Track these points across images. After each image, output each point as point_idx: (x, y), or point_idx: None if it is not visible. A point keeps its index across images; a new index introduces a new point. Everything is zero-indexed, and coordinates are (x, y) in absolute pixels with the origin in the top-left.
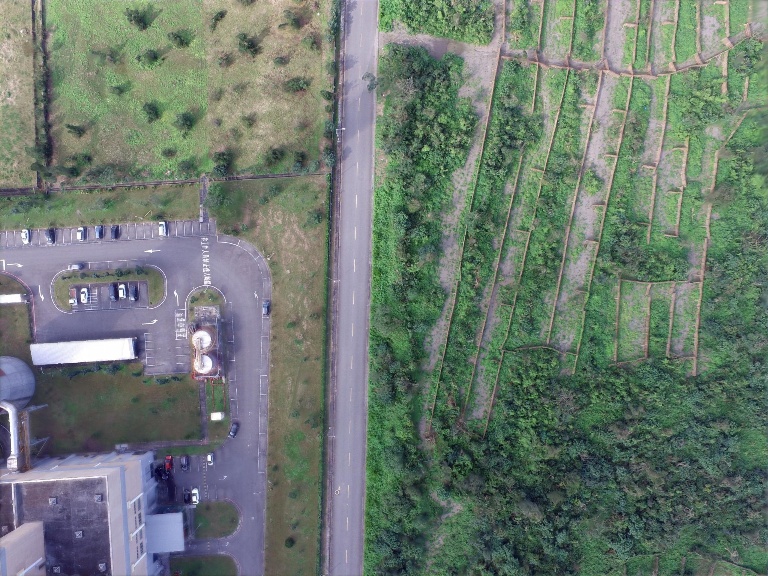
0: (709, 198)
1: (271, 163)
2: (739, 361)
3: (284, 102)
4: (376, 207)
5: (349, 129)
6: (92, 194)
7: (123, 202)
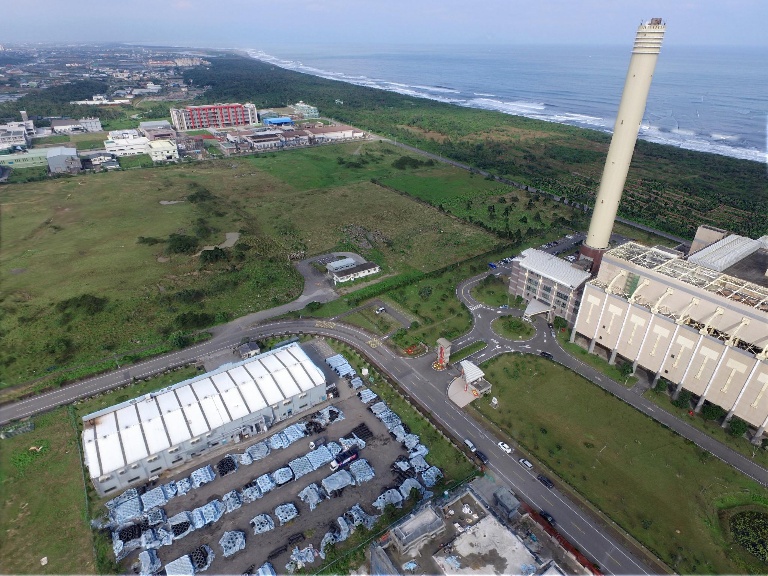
0: (692, 192)
1: (577, 218)
2: (767, 210)
3: (558, 210)
4: (621, 216)
5: (584, 209)
6: (533, 239)
7: (546, 237)
